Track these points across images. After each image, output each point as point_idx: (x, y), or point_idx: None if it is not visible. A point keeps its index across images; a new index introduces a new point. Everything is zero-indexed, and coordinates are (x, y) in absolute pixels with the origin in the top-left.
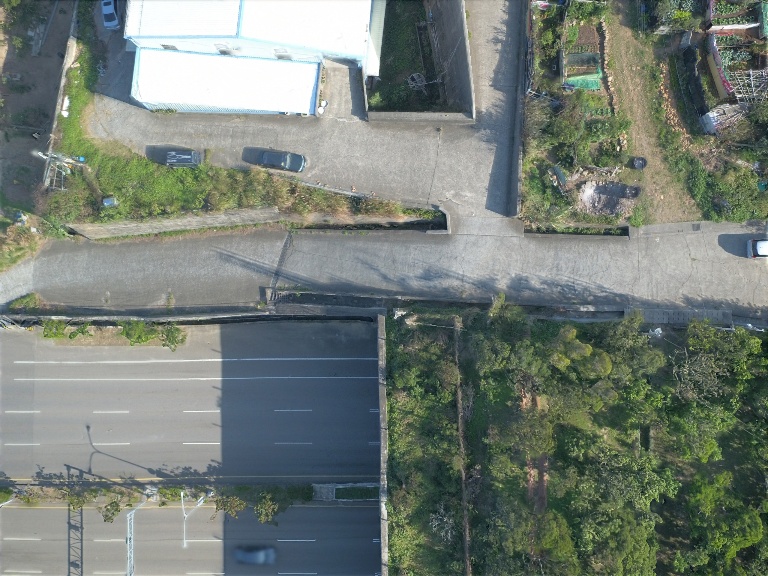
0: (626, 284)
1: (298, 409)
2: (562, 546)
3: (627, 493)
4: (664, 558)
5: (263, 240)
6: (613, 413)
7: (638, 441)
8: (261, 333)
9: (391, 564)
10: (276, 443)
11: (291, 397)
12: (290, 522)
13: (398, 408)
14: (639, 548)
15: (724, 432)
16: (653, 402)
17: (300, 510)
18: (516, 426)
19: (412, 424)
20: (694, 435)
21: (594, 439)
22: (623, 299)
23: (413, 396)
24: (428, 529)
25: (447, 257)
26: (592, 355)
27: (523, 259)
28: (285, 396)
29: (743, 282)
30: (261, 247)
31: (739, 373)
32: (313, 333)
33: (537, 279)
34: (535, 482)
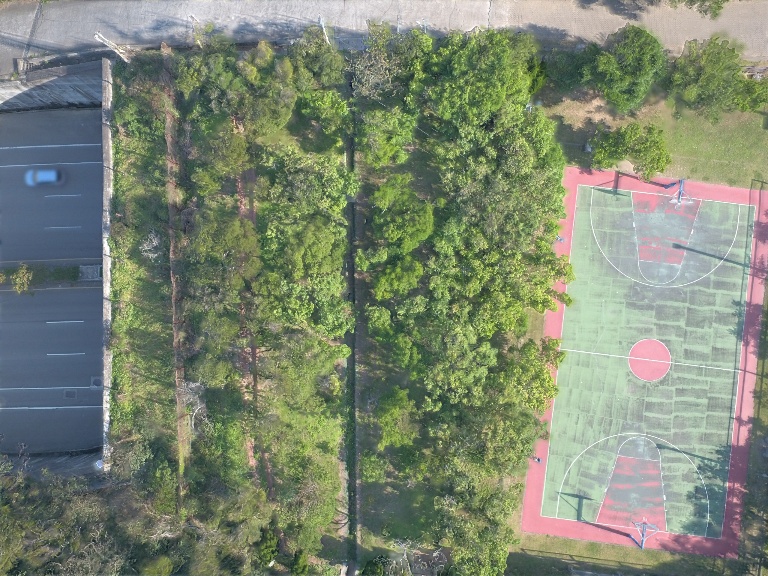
0: (333, 17)
1: (67, 194)
2: (245, 244)
3: (309, 193)
4: (366, 276)
5: (16, 13)
6: (318, 139)
7: (343, 166)
8: (32, 121)
9: (114, 299)
10: (46, 228)
11: (61, 183)
12: (59, 304)
13: (122, 149)
14: (317, 243)
15: (422, 152)
16: (338, 109)
17: (68, 292)
18: (212, 140)
19: (134, 163)
20: (371, 134)
21: (282, 146)
22: (330, 31)
23: (131, 132)
24: (148, 262)
25: (173, 5)
26: (271, 57)
27: (242, 2)
28: (55, 182)
29: (440, 8)
30: (15, 20)
31: (412, 73)
32: (82, 120)
33: (254, 20)
34: (246, 210)
